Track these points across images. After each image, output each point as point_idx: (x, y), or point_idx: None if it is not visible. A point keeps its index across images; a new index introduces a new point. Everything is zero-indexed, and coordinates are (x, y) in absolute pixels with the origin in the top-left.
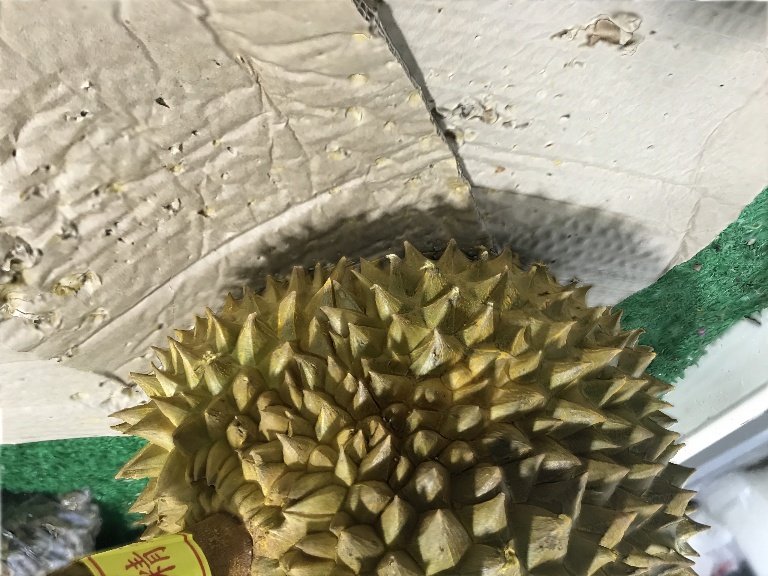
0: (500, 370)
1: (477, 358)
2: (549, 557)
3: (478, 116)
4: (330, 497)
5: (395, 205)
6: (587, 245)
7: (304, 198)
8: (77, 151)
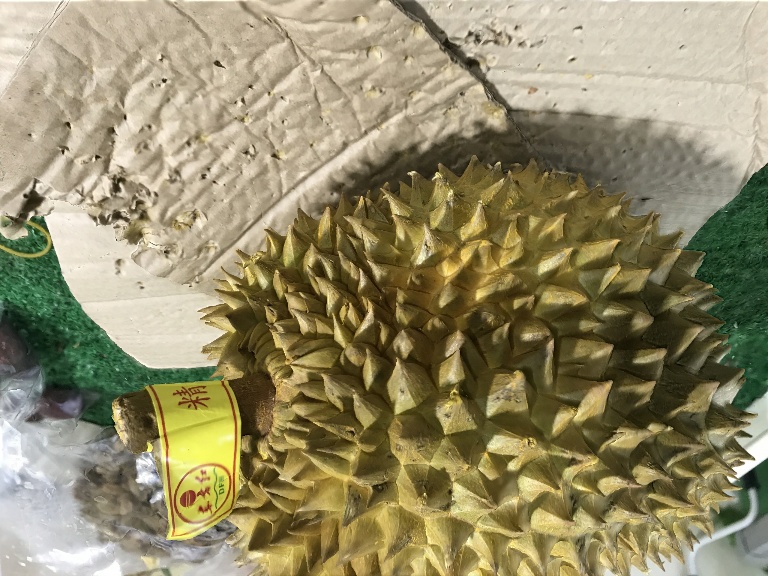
0: (486, 258)
1: (466, 248)
2: (507, 408)
3: (490, 40)
4: (325, 354)
5: (441, 136)
6: (646, 159)
7: (356, 136)
8: (167, 111)
